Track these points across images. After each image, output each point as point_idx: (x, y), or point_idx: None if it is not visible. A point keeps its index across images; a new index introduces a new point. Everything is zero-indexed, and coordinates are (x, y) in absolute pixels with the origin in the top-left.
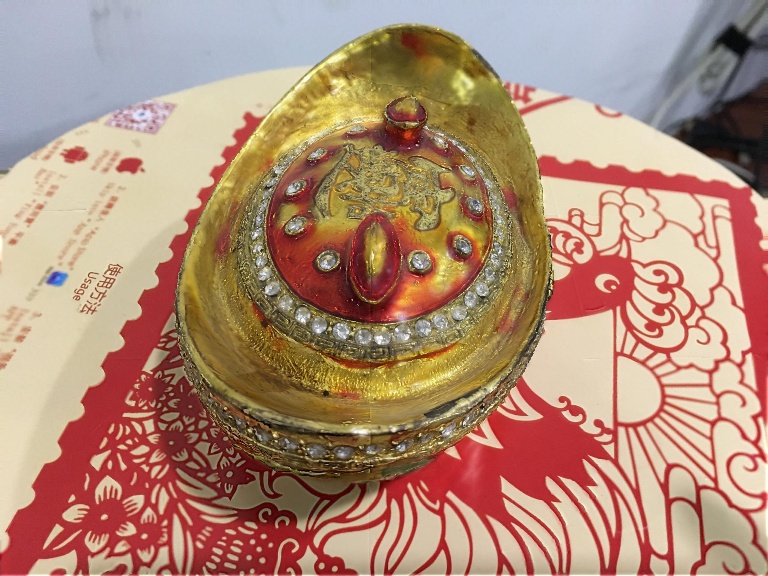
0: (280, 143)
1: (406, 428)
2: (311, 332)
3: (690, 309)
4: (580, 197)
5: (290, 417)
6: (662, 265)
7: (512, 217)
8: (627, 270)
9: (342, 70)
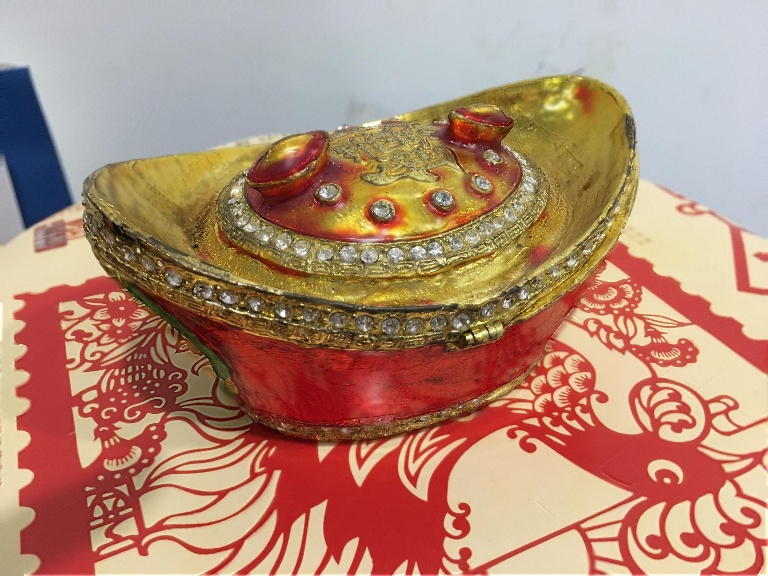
0: None
1: (125, 228)
2: (224, 199)
3: (737, 571)
4: (755, 394)
5: None
6: (767, 512)
7: (523, 269)
8: (711, 482)
9: (512, 100)
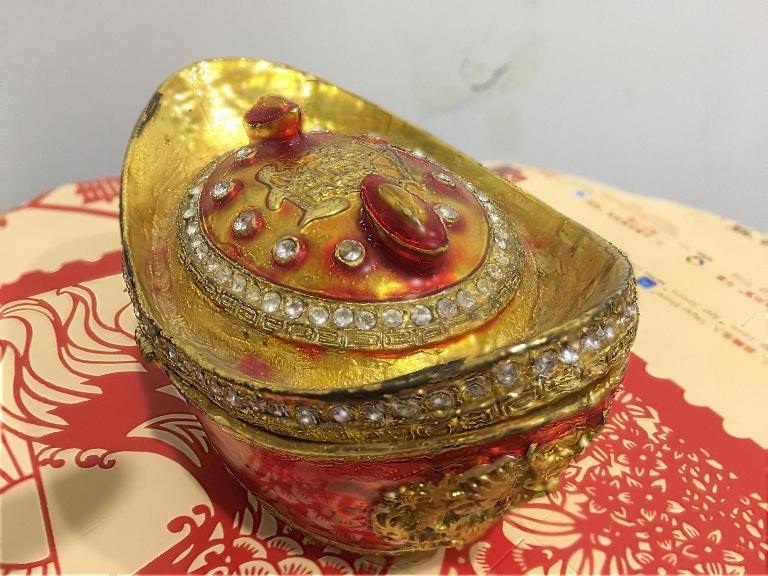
0: (554, 252)
1: None
2: None
3: None
4: None
5: (233, 58)
6: None
7: (231, 357)
8: None
9: None
